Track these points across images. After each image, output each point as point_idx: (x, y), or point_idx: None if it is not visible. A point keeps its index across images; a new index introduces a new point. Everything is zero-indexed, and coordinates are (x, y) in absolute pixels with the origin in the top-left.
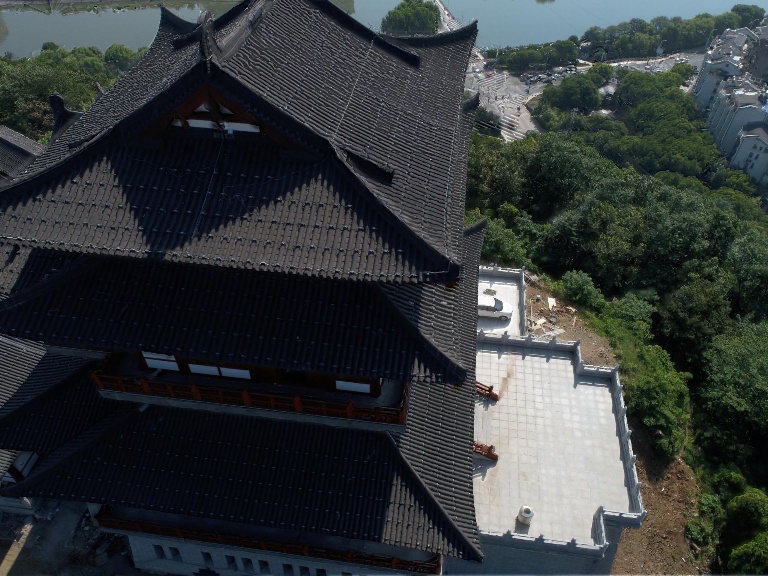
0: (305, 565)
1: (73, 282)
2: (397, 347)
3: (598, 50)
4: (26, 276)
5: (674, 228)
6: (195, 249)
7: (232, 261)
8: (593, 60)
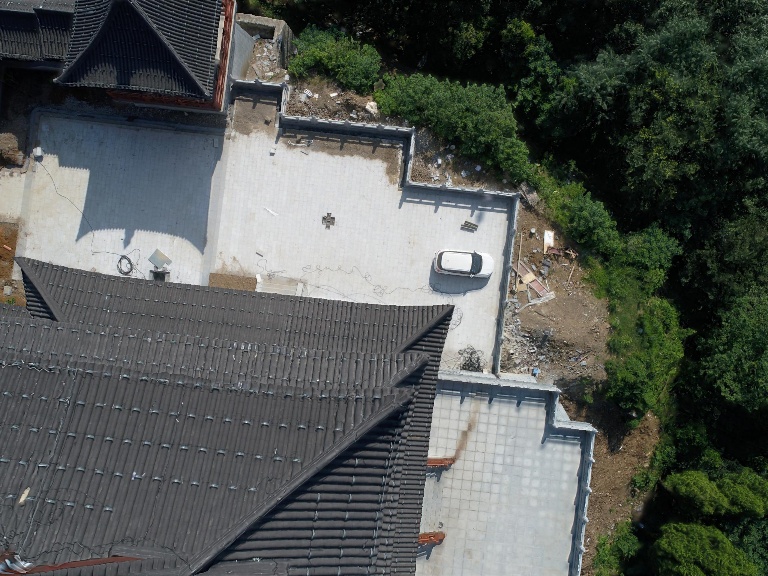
0: None
1: None
2: None
3: None
4: None
5: None
6: None
7: None
8: None
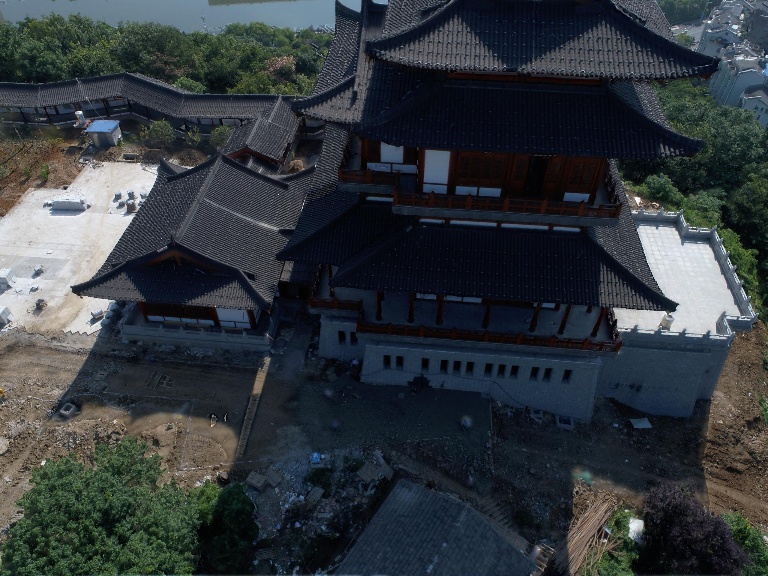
0: (504, 363)
1: (412, 110)
2: (645, 139)
3: None
4: (368, 112)
5: (736, 137)
6: (535, 66)
7: (563, 71)
8: None
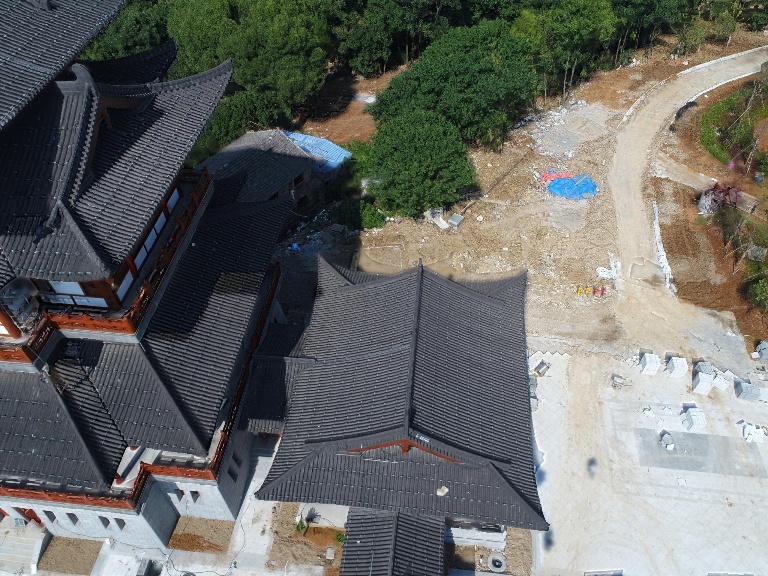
0: None
1: None
2: None
3: None
4: None
5: None
6: None
7: None
8: None
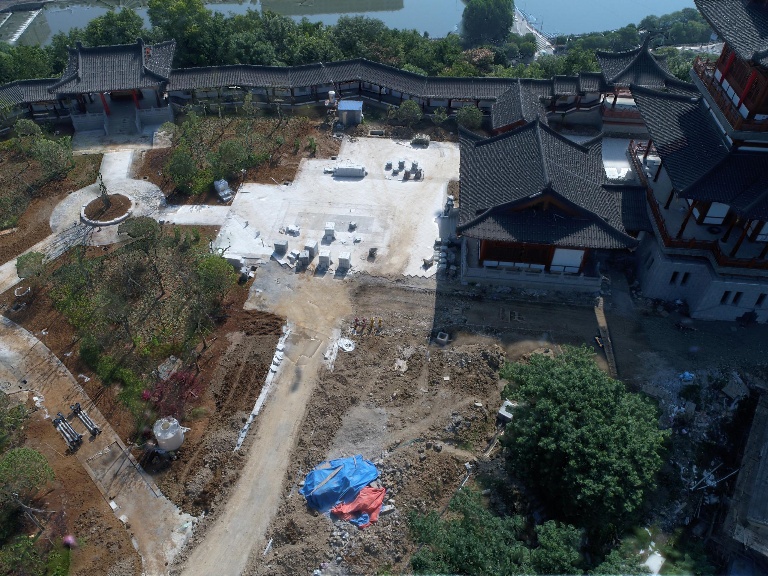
0: None
1: None
2: None
3: (653, 37)
4: None
5: None
6: None
7: None
8: (657, 45)
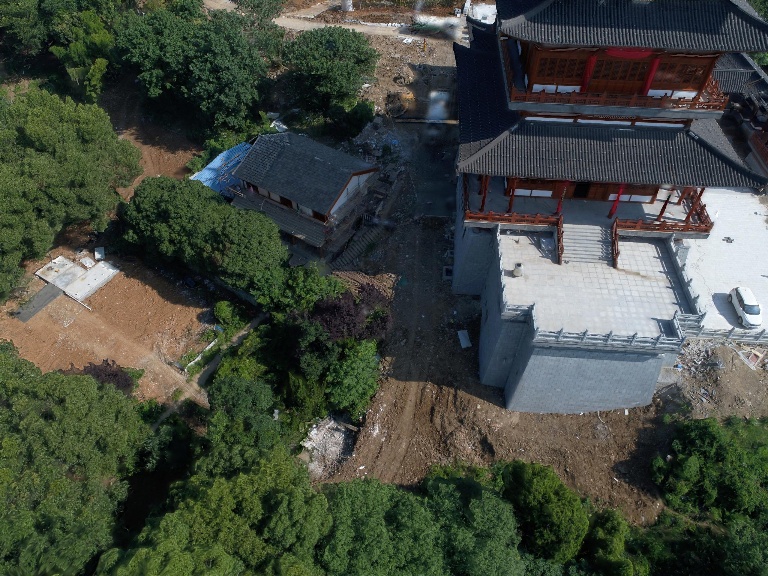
0: None
1: None
2: None
3: None
4: None
5: None
6: None
7: None
8: None
